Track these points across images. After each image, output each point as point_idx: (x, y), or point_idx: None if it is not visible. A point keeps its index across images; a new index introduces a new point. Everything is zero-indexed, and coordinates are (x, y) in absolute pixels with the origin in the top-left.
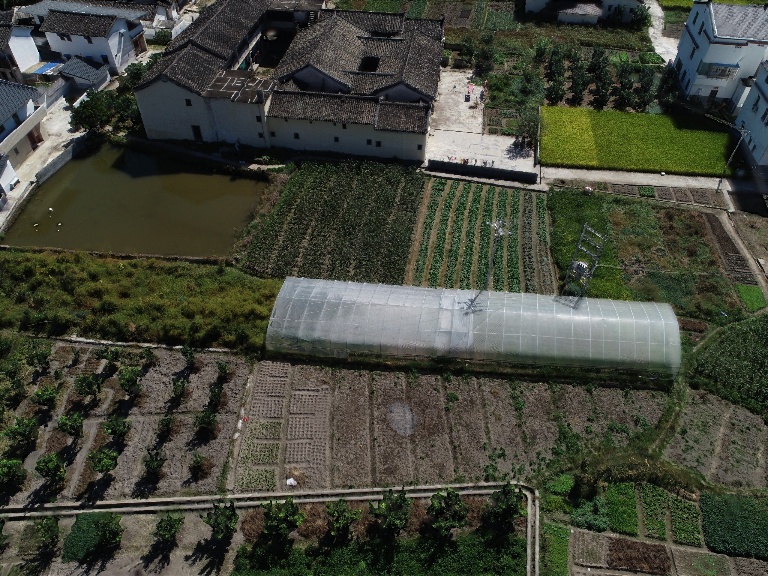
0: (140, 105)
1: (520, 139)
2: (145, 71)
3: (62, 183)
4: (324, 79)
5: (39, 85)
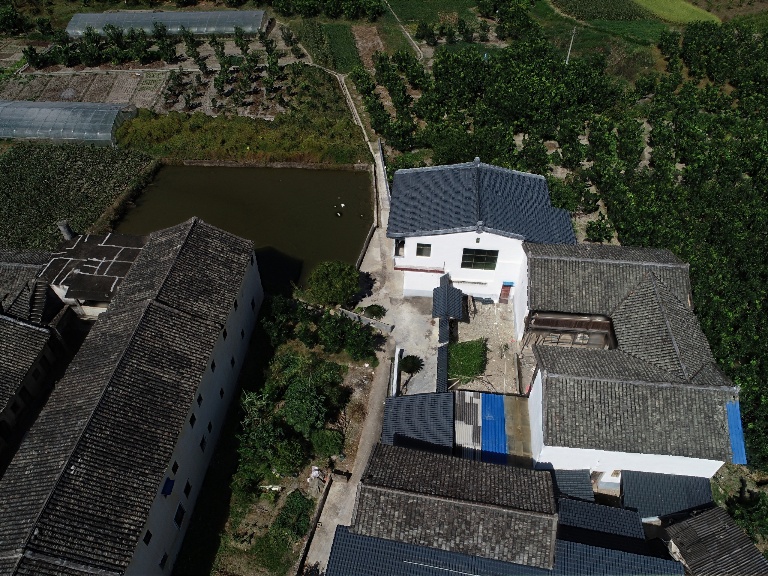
0: None
1: None
2: None
3: None
4: None
5: (471, 368)
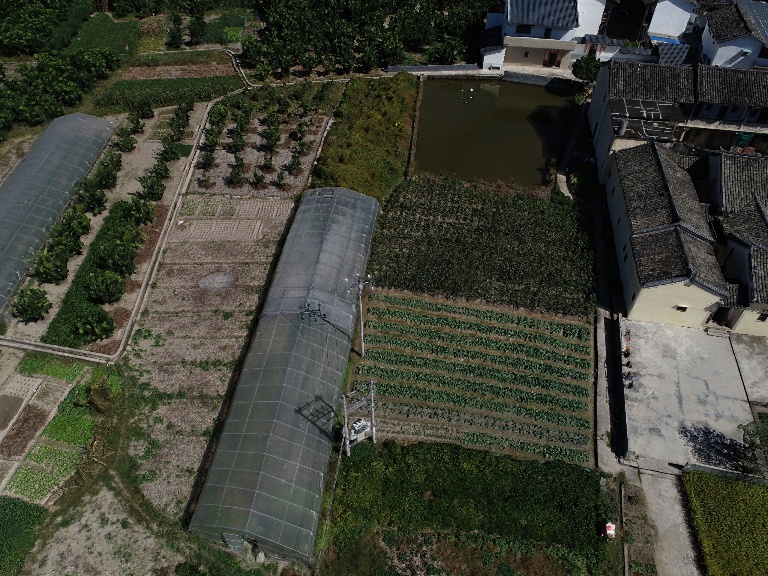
0: None
1: (759, 458)
2: None
3: (528, 98)
4: (717, 180)
5: (633, 43)
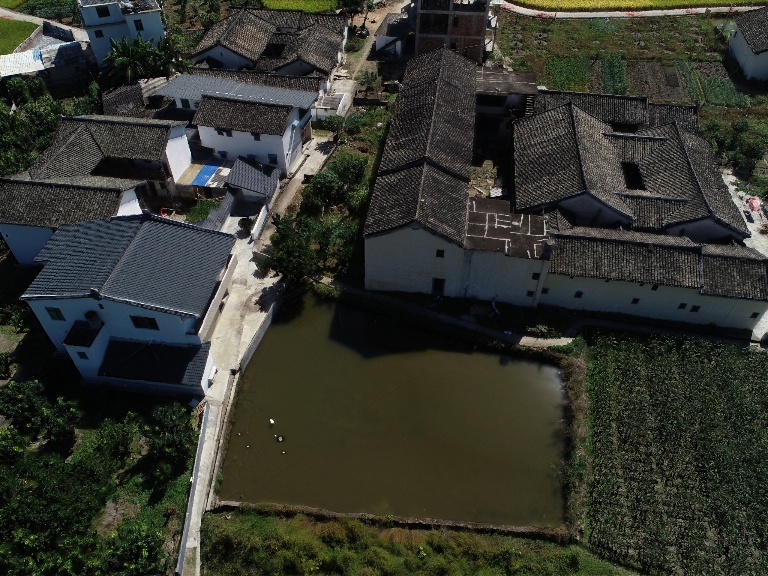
0: (368, 253)
1: None
2: (336, 182)
3: None
4: (601, 209)
5: (203, 204)
